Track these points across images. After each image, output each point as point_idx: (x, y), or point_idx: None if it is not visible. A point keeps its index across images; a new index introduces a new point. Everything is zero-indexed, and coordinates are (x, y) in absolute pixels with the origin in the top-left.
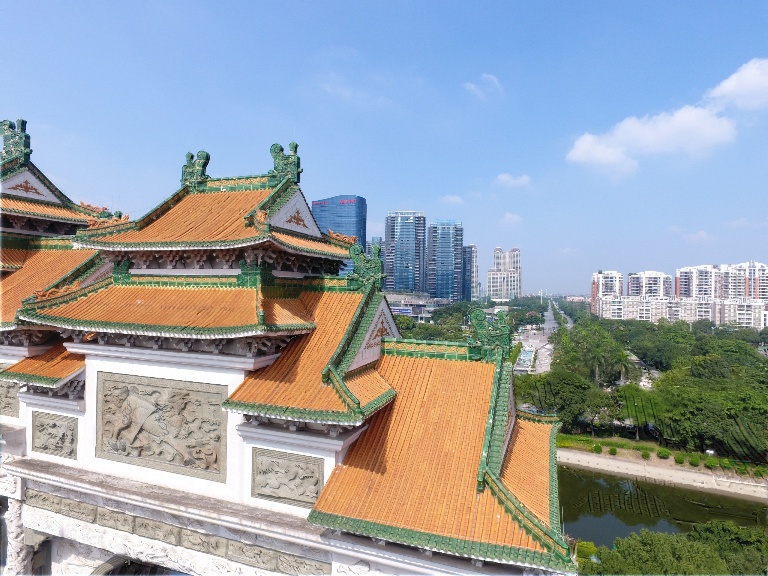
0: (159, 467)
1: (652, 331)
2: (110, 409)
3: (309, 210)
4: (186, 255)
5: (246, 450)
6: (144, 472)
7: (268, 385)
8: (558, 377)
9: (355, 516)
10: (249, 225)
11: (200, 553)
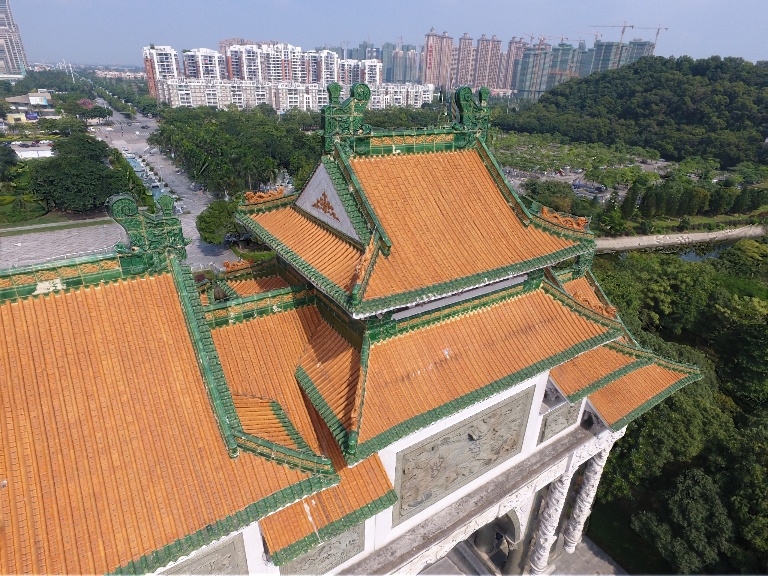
0: (465, 483)
1: (245, 123)
2: (415, 476)
3: None
4: None
5: (539, 420)
6: (450, 498)
7: (569, 367)
8: None
9: (627, 412)
10: None
11: (490, 510)
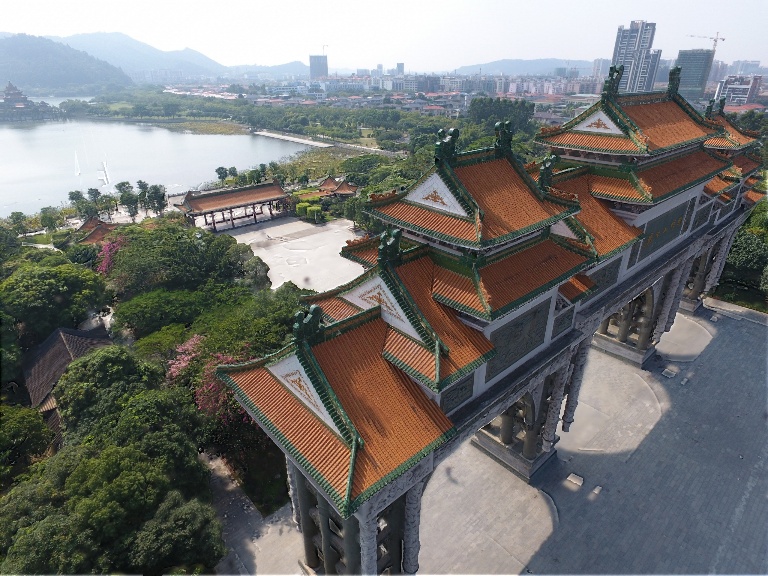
0: None
1: None
2: None
3: (450, 190)
4: None
5: None
6: None
7: None
8: None
9: None
10: None
11: None
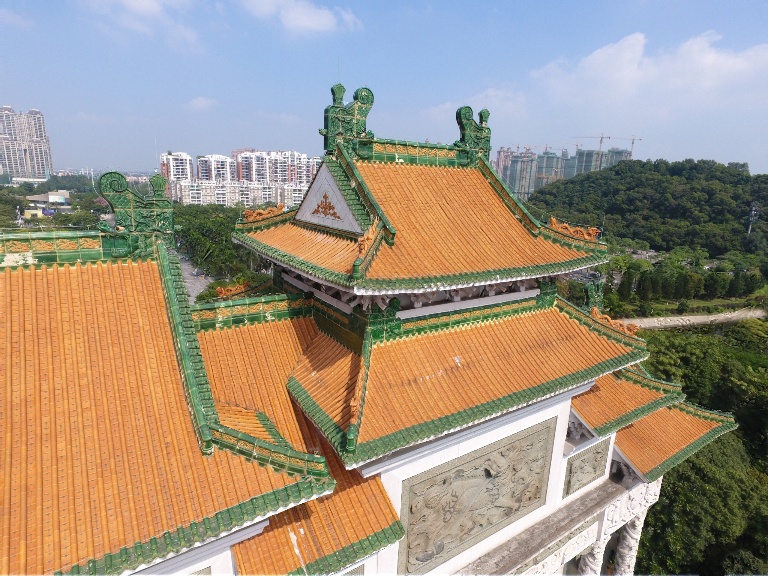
0: (482, 537)
1: None
2: (424, 517)
3: None
4: (510, 284)
5: (564, 464)
6: (466, 555)
7: (592, 399)
8: (259, 281)
9: (661, 461)
10: (537, 235)
11: None
